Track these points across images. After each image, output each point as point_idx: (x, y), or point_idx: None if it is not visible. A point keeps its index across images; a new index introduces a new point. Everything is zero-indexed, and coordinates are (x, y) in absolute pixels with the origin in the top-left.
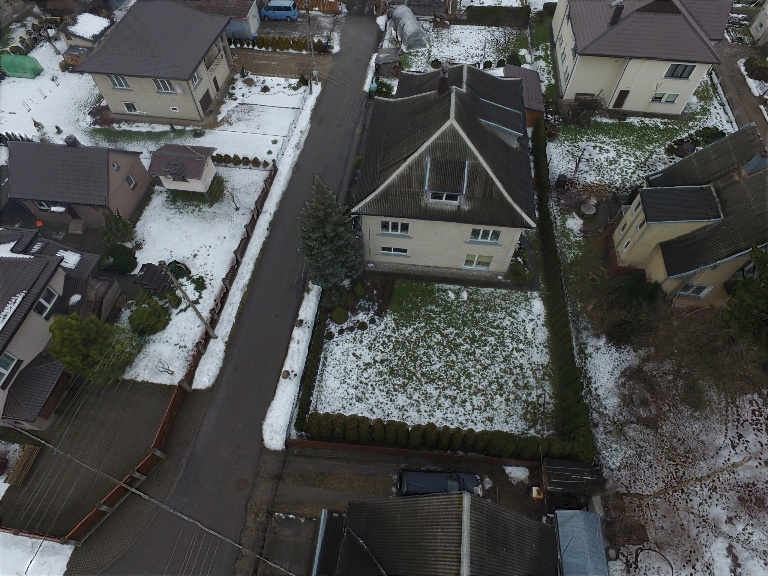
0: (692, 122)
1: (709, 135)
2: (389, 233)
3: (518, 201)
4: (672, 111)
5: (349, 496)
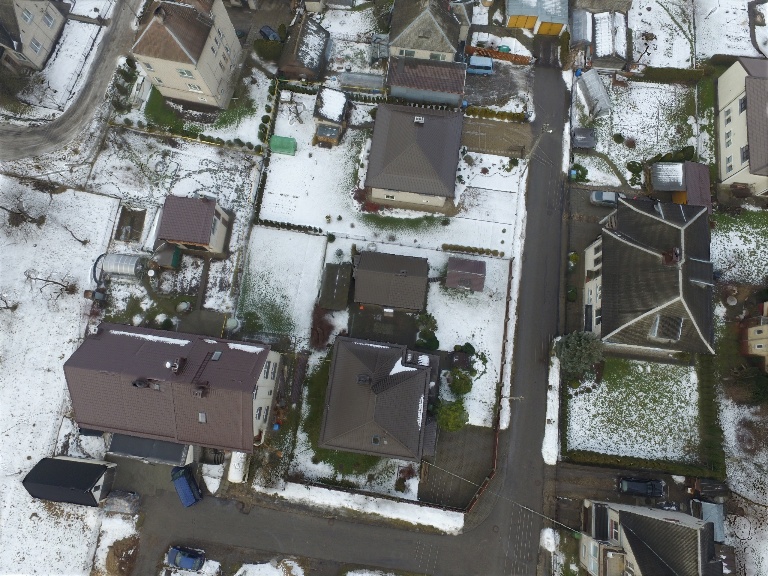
0: None
1: None
2: None
3: (706, 337)
4: None
5: (593, 489)
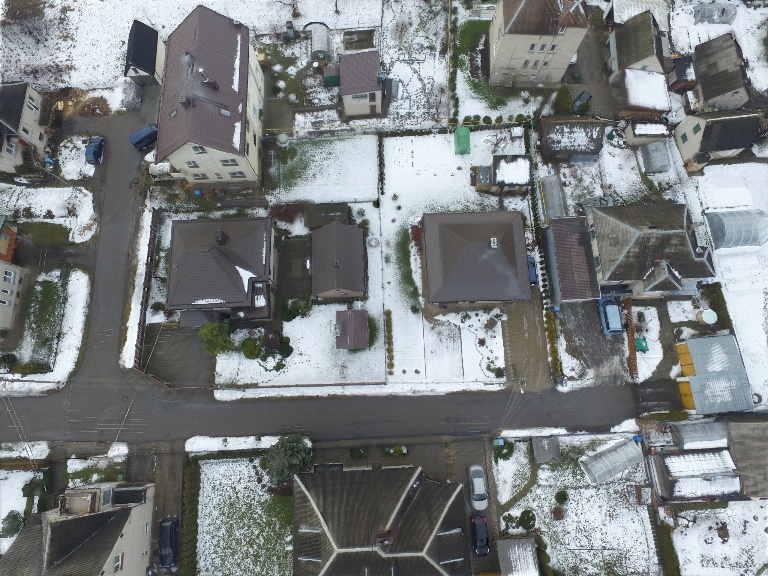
0: None
1: None
2: None
3: None
4: None
5: (165, 492)
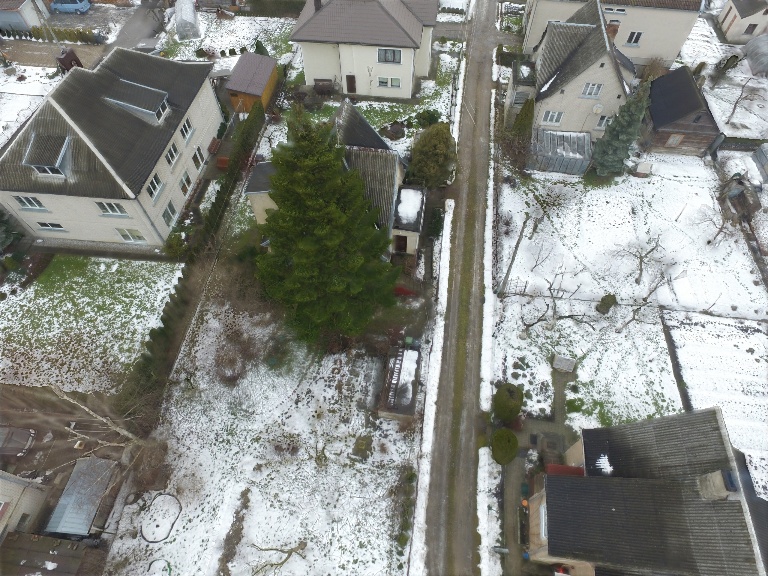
0: (418, 105)
1: (425, 117)
2: (30, 208)
3: (124, 174)
4: (402, 95)
5: None
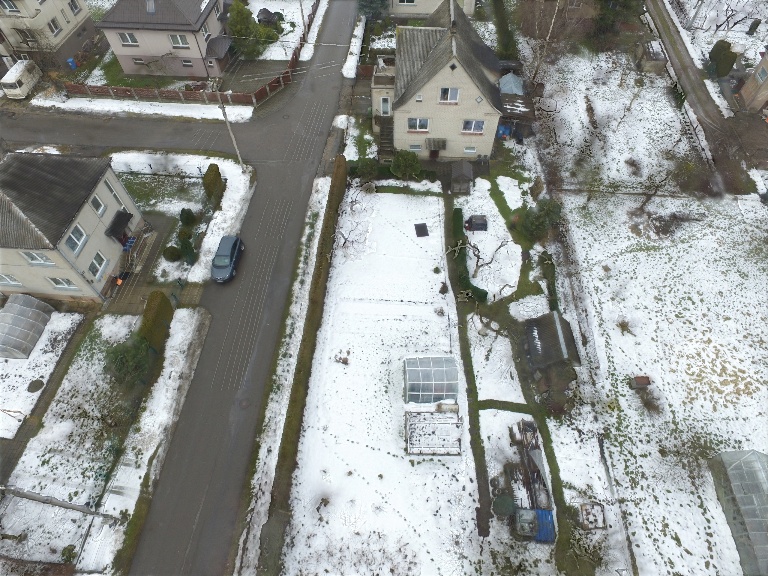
0: None
1: None
2: None
3: None
4: None
5: None
